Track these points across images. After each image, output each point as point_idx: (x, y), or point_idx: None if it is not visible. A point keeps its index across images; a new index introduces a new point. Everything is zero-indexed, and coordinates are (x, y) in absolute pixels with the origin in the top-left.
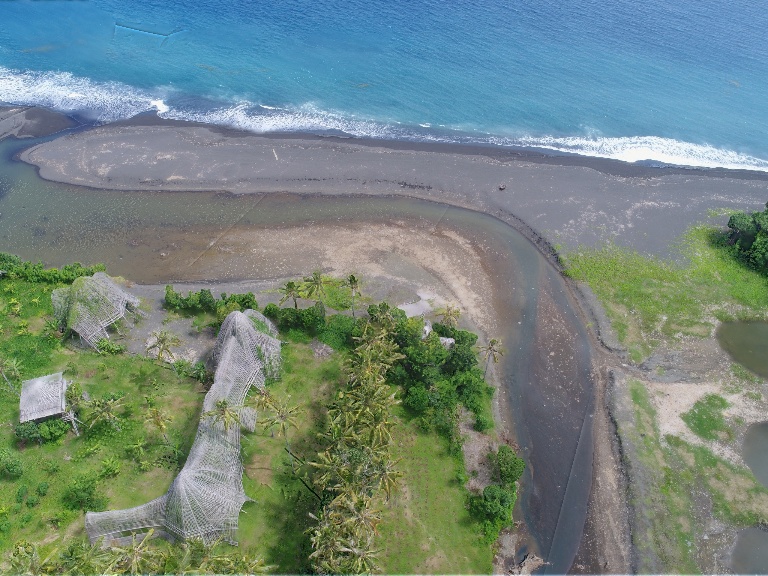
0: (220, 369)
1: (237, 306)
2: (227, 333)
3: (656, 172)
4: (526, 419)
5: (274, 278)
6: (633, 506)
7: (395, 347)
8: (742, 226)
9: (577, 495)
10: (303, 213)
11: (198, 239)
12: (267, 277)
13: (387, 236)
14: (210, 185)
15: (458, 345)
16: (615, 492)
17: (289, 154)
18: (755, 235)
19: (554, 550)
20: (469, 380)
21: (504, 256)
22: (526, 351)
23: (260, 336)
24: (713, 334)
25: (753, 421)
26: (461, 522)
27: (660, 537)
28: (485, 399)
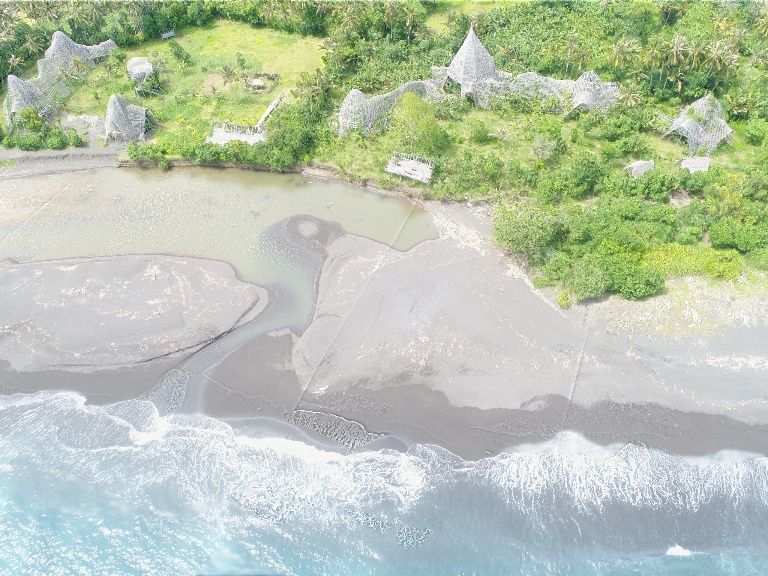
0: (38, 77)
1: None
2: None
3: None
4: None
5: (2, 179)
6: None
7: None
8: None
9: None
10: None
11: (58, 207)
12: (7, 180)
13: None
14: None
15: None
16: None
17: None
18: None
19: None
20: None
21: None
22: None
23: None
24: None
25: None
26: None
27: None
28: None
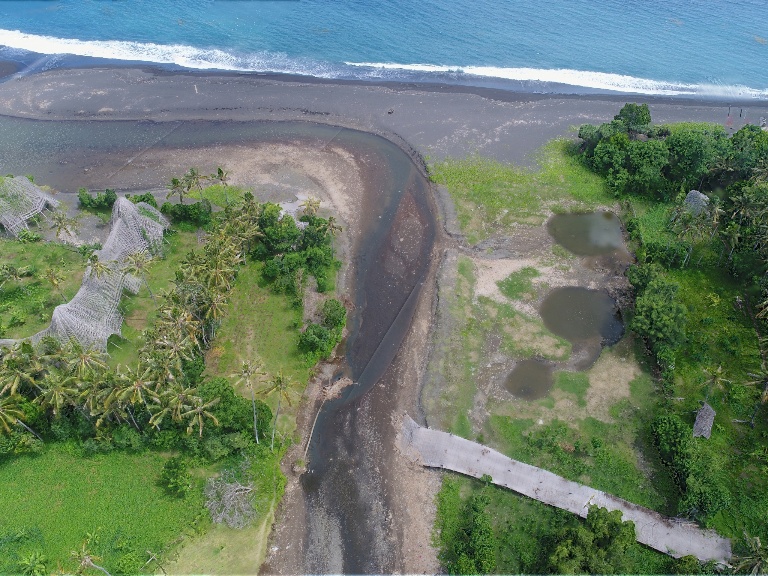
0: (107, 242)
1: (131, 200)
2: (115, 216)
3: (536, 97)
4: (366, 286)
5: None
6: (434, 344)
7: (256, 227)
8: (586, 135)
9: (393, 338)
10: (213, 136)
11: (118, 158)
12: None
13: (282, 153)
14: (135, 115)
15: (309, 226)
16: (424, 336)
17: (208, 88)
18: (598, 142)
19: (364, 375)
20: (316, 253)
21: (381, 167)
22: (380, 238)
23: (144, 219)
24: (544, 223)
25: (557, 286)
26: (290, 354)
27: (450, 364)
28: (332, 270)
